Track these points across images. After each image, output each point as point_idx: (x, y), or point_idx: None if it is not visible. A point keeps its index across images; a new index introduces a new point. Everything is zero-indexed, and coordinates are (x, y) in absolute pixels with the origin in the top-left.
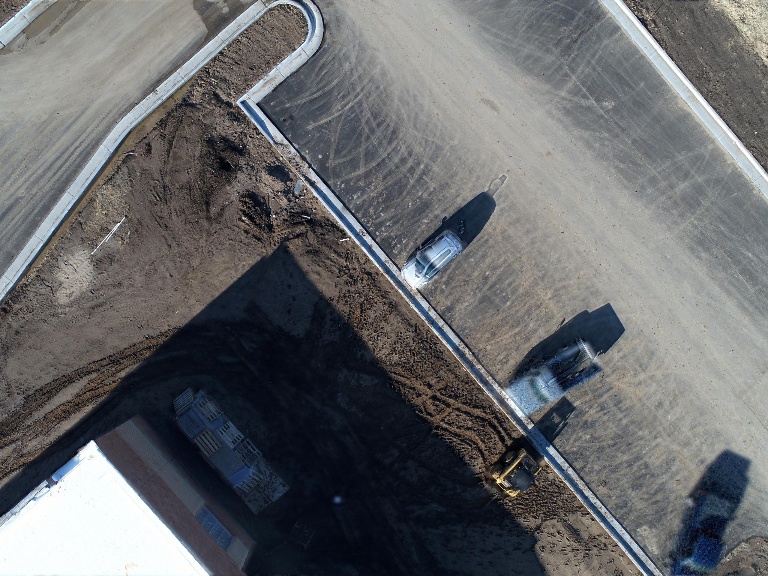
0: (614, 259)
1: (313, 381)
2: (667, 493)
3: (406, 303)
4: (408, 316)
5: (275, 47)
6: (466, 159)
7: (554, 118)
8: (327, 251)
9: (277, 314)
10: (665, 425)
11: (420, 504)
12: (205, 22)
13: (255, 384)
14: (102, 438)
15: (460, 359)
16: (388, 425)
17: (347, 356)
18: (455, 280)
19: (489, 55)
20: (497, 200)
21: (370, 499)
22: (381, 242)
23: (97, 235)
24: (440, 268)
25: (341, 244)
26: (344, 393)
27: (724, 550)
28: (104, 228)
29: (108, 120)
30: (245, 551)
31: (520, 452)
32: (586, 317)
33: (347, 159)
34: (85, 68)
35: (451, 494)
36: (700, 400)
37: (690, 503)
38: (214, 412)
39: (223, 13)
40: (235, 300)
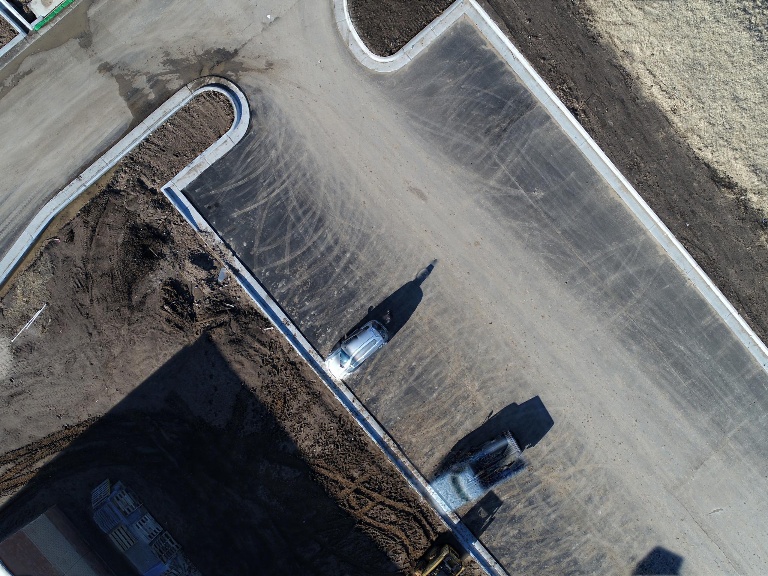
0: (543, 351)
1: (234, 473)
2: None
3: (330, 393)
4: (332, 407)
5: (200, 134)
6: (393, 248)
7: (482, 207)
8: (251, 340)
9: (198, 404)
10: (595, 521)
11: None
12: (130, 108)
13: (175, 475)
14: (5, 543)
15: (384, 452)
16: (310, 519)
17: (269, 448)
18: (380, 371)
19: (417, 143)
20: (424, 290)
21: None
22: (305, 331)
23: (18, 322)
24: (365, 358)
25: (265, 333)
26: (265, 485)
27: None
28: (25, 315)
29: (31, 206)
30: None
31: (444, 549)
32: (514, 409)
33: (272, 247)
34: (9, 153)
35: None
36: (631, 496)
37: None
38: (132, 505)
39: (149, 99)
40: (156, 389)
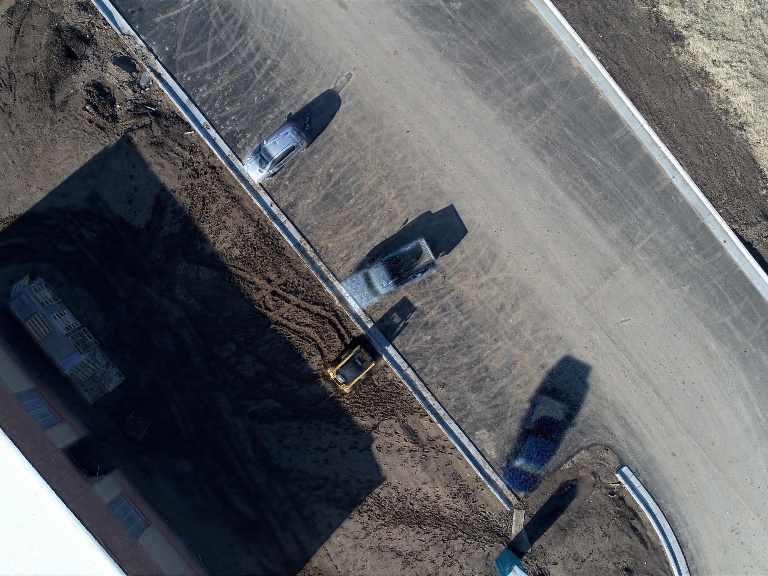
0: (458, 160)
1: (152, 272)
2: (507, 397)
3: (249, 198)
4: (251, 211)
5: None
6: (313, 56)
7: (401, 17)
8: (171, 143)
9: (118, 204)
10: (507, 329)
11: (257, 399)
12: None
13: (94, 273)
14: None
15: (300, 255)
16: (226, 318)
17: (187, 248)
18: (299, 176)
19: None
20: (343, 98)
21: (207, 392)
22: (225, 136)
23: None
24: (284, 164)
25: (186, 137)
26: (183, 285)
27: (563, 457)
28: None
29: None
30: (73, 435)
31: (355, 348)
32: (429, 218)
33: (194, 52)
34: None
35: (288, 390)
36: (542, 305)
37: (530, 408)
38: (50, 298)
39: None
40: (77, 189)
